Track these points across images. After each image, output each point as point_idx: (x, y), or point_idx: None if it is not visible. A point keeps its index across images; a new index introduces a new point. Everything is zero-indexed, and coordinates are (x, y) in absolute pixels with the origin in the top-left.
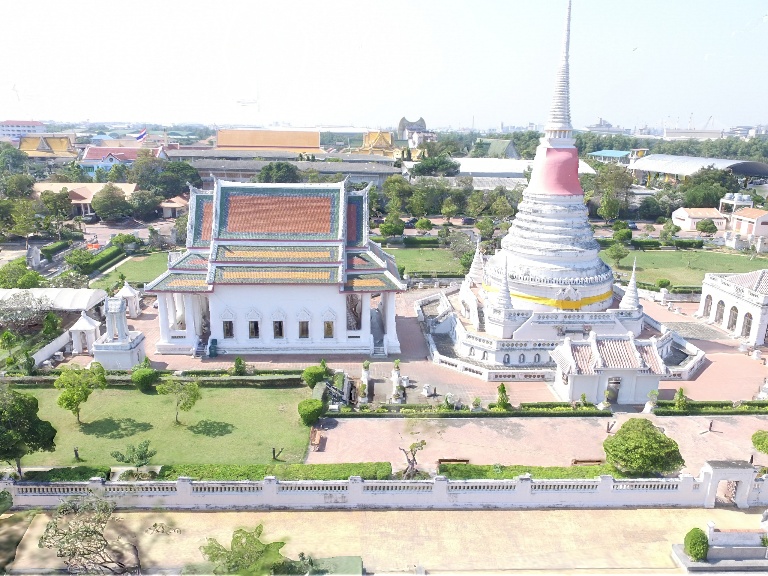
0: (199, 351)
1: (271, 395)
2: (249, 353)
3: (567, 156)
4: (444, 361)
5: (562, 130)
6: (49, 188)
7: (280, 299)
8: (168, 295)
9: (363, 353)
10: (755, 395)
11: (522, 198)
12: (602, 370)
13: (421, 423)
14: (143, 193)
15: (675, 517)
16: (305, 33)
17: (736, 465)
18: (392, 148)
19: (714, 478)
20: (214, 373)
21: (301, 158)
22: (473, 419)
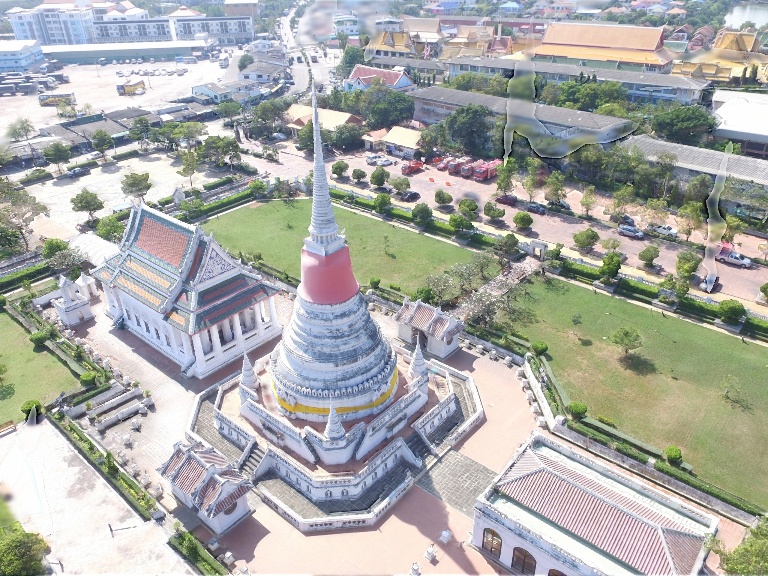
0: (117, 322)
1: (65, 381)
2: (137, 335)
3: (312, 263)
4: None
5: None
6: (298, 110)
7: None
8: None
9: None
10: None
11: (683, 207)
12: None
13: (63, 450)
14: (346, 126)
15: None
16: None
17: None
18: None
19: None
20: None
21: (581, 77)
22: (87, 465)
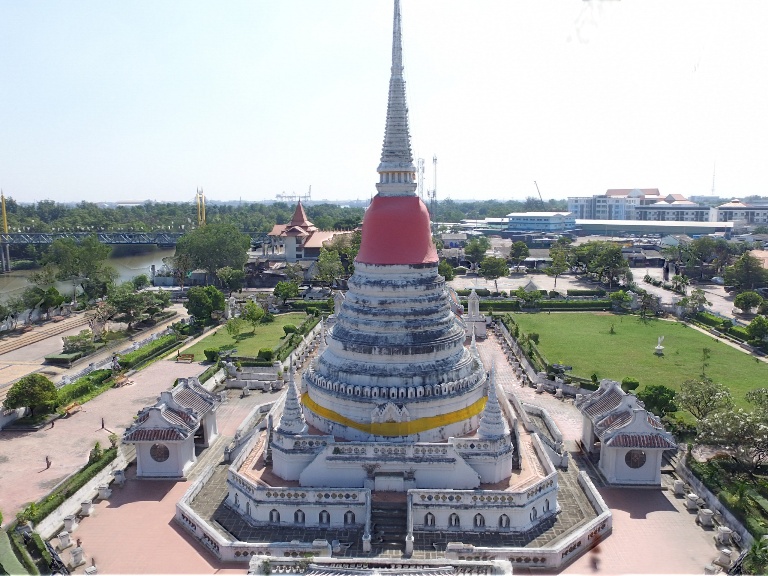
0: None
1: None
2: None
3: None
4: None
5: None
6: None
7: None
8: None
9: None
10: (89, 557)
11: None
12: None
13: None
14: None
15: None
16: None
17: None
18: None
19: None
20: None
21: None
22: None
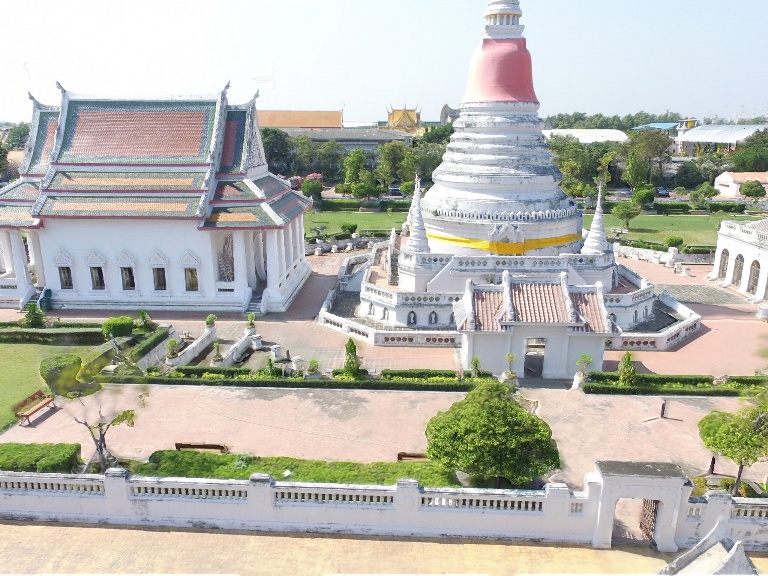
0: (29, 304)
1: (52, 353)
2: (92, 308)
3: (510, 48)
4: (329, 320)
5: (504, 14)
6: None
7: (127, 238)
8: (2, 235)
9: (235, 311)
10: None
11: None
12: (512, 325)
13: (218, 393)
14: None
15: (526, 562)
16: (324, 5)
17: (650, 471)
18: (417, 127)
19: (606, 493)
20: (2, 325)
21: None
22: (299, 390)
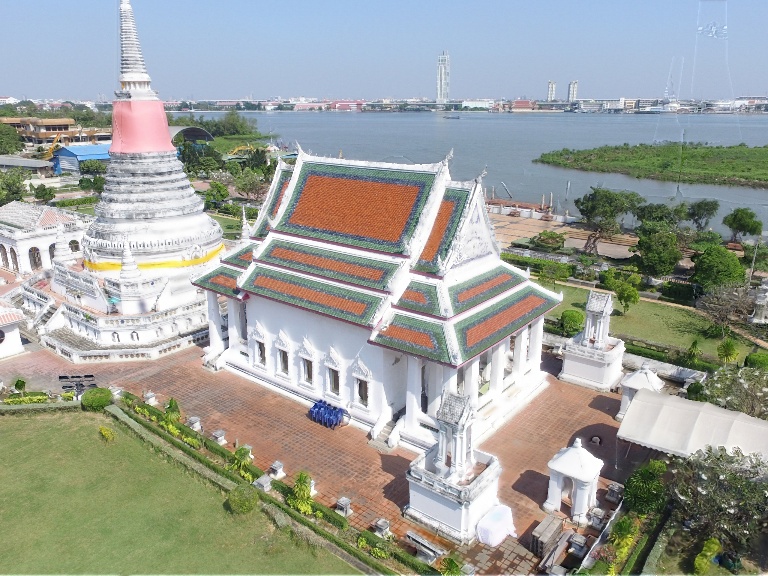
0: None
1: None
2: None
3: None
4: None
5: None
6: None
7: None
8: None
9: None
10: None
11: None
12: None
13: None
14: None
15: None
16: None
17: None
18: None
19: None
20: None
21: None
22: None
